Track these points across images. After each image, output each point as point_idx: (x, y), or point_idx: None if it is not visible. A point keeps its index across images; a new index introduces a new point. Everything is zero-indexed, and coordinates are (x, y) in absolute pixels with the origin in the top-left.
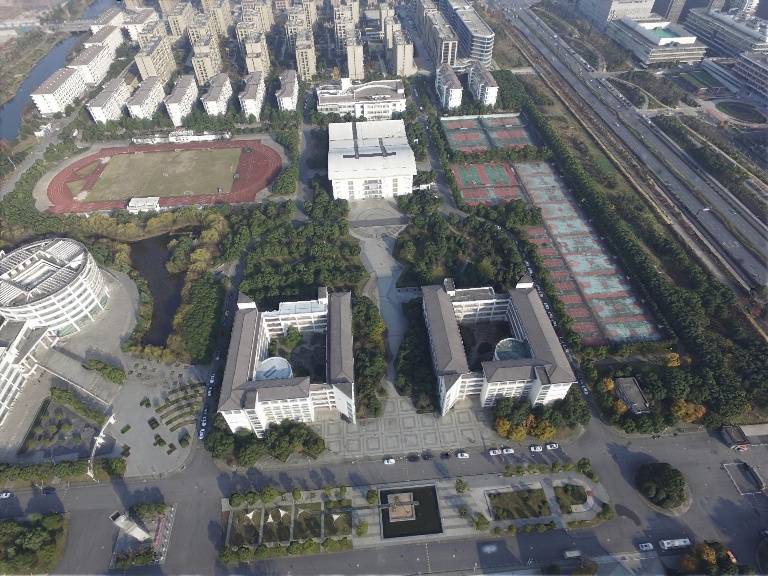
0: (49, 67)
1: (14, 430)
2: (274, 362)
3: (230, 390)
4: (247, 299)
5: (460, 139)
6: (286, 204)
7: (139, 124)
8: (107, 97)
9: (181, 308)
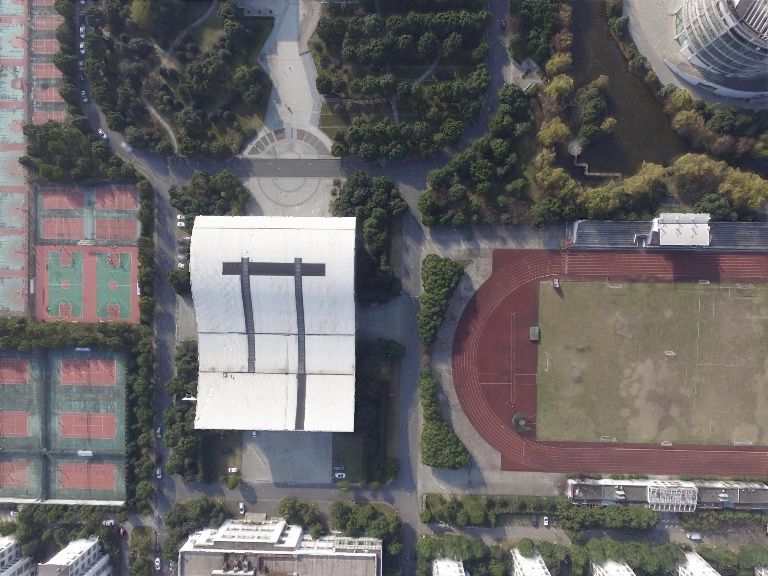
0: None
1: None
2: None
3: None
4: None
5: (102, 417)
6: (434, 202)
7: None
8: None
9: None
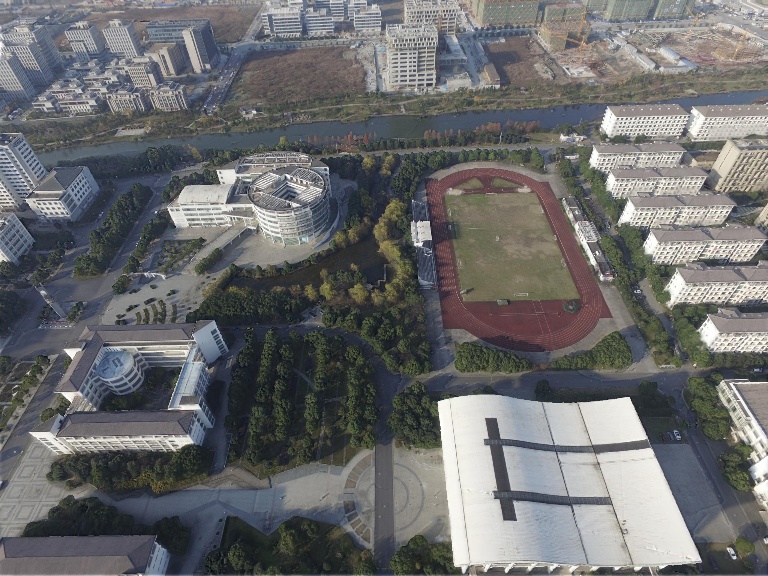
0: (733, 101)
1: (186, 233)
2: (127, 364)
3: (97, 330)
4: (199, 327)
5: None
6: None
7: (599, 192)
8: (624, 151)
9: (245, 288)
